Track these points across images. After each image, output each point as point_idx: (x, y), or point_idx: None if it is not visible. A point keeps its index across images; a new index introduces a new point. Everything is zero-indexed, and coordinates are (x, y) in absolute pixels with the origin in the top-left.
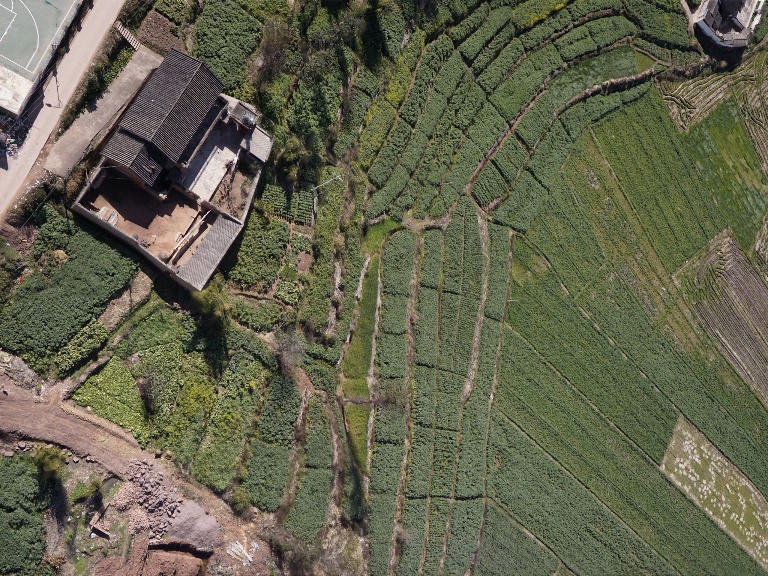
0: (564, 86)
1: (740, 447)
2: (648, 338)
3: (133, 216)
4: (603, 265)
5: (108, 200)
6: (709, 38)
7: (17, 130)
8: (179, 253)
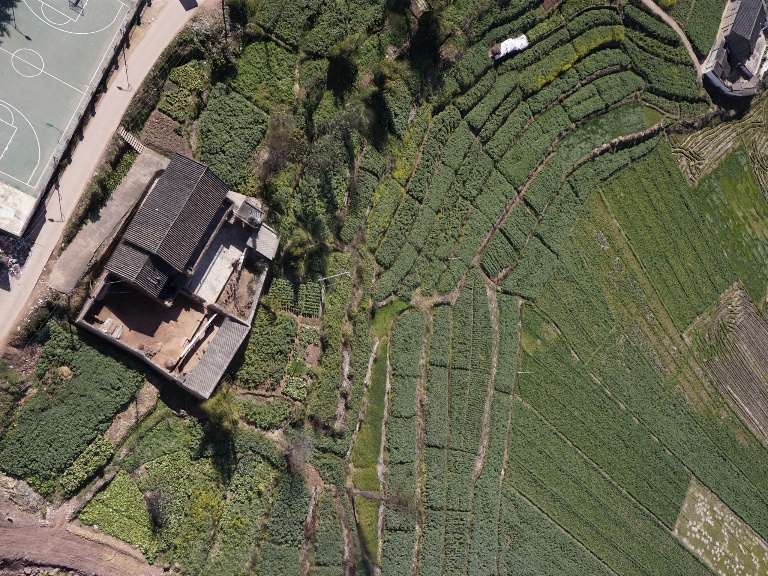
0: (572, 147)
1: (753, 505)
2: (659, 400)
3: (138, 325)
4: (613, 328)
5: (113, 311)
6: (718, 88)
7: (19, 249)
8: (185, 358)
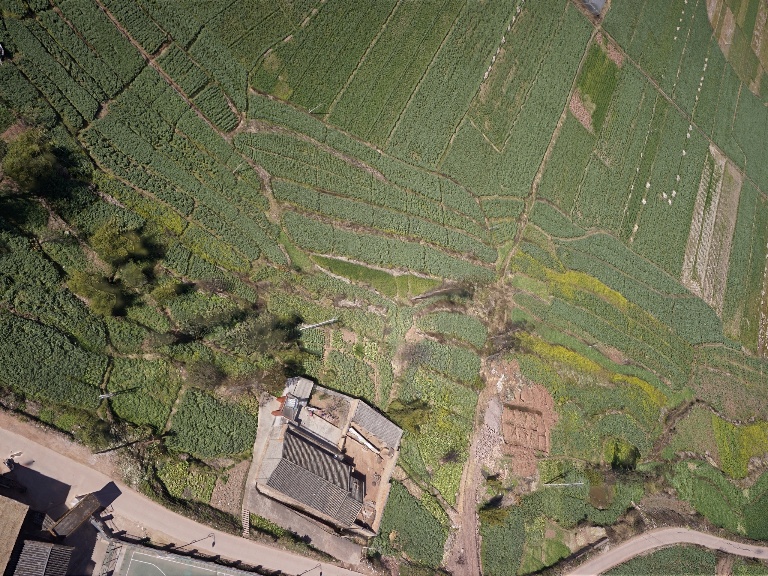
0: None
1: None
2: None
3: None
4: None
5: None
6: None
7: None
8: None
